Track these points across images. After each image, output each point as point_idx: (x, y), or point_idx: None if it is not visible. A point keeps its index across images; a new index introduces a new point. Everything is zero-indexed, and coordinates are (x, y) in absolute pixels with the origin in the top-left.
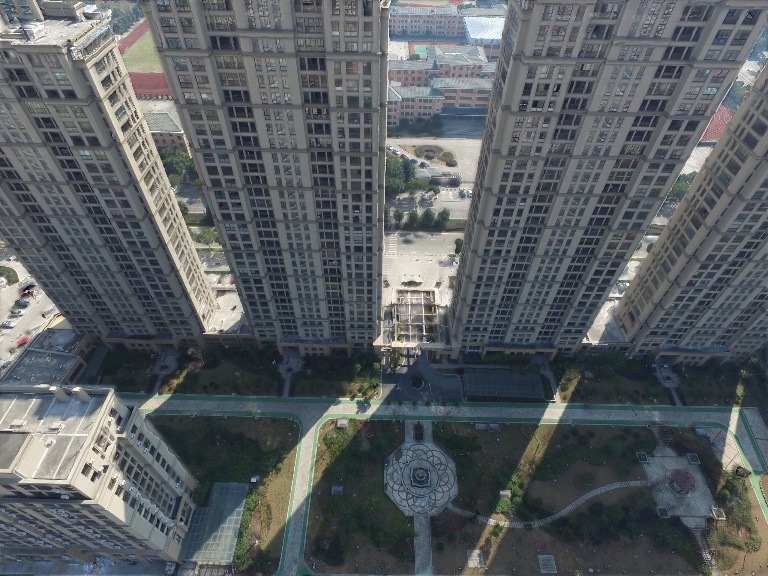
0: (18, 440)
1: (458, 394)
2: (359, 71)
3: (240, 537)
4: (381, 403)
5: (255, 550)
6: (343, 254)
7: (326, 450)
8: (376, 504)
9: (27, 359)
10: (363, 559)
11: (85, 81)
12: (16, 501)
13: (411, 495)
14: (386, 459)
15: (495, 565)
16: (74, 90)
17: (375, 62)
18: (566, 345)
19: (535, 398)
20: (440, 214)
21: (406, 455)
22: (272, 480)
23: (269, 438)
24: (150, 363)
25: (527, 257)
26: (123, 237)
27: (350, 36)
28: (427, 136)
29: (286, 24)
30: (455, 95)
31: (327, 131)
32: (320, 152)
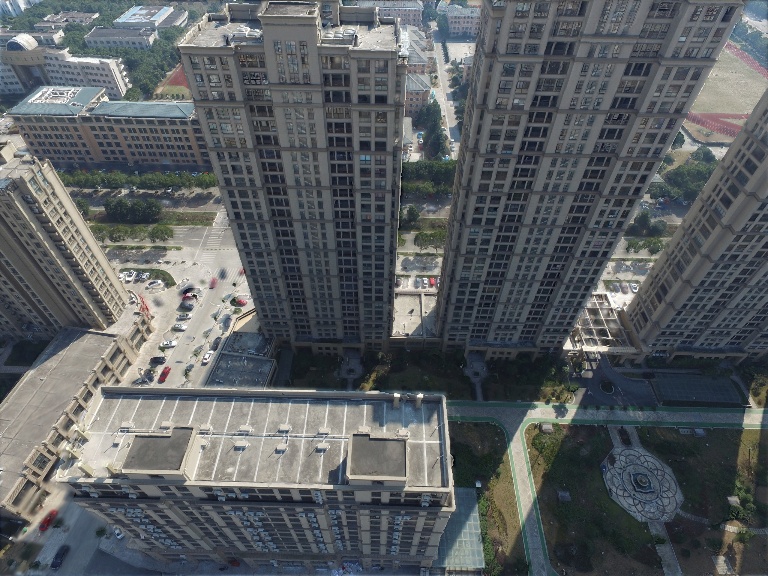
0: (397, 447)
1: (652, 399)
2: (687, 77)
3: (484, 543)
4: (577, 407)
5: (501, 556)
6: (576, 259)
7: (538, 455)
8: (607, 510)
9: (223, 362)
10: (611, 565)
11: (396, 86)
12: (374, 508)
13: (638, 501)
14: (601, 464)
15: (745, 572)
16: (387, 95)
17: (708, 68)
18: (755, 350)
19: (733, 403)
20: None
21: (620, 460)
22: (495, 485)
23: (478, 443)
24: (336, 367)
25: (757, 262)
26: (361, 241)
27: (696, 42)
28: None
29: (635, 30)
30: None
31: (618, 136)
32: (600, 157)
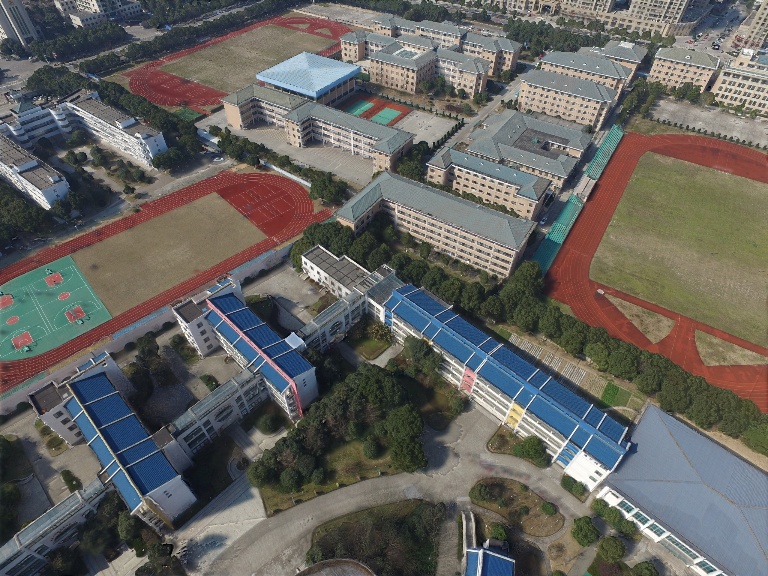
0: None
1: None
2: None
3: None
4: None
5: None
6: None
7: None
8: None
9: None
10: None
11: None
12: None
13: None
14: None
15: None
16: None
17: None
18: None
19: None
20: (513, 20)
21: None
22: None
23: None
24: None
25: None
26: None
27: None
28: None
29: None
30: None
31: None
32: None
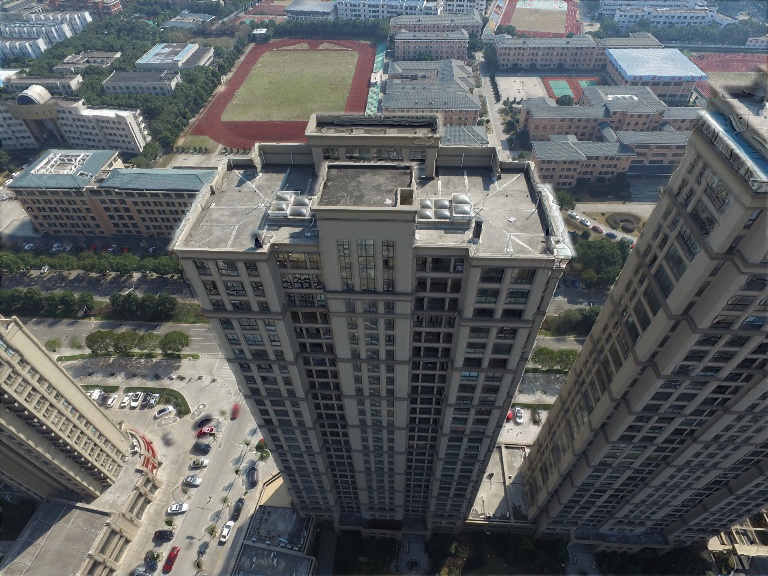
0: None
1: None
2: None
3: None
4: None
5: None
6: (765, 475)
7: None
8: None
9: (246, 559)
10: None
11: None
12: None
13: None
14: None
15: None
16: (524, 309)
17: None
18: None
19: None
20: None
21: None
22: None
23: None
24: (394, 557)
25: None
26: (445, 449)
27: None
28: (613, 200)
29: None
30: (647, 151)
31: None
32: None
